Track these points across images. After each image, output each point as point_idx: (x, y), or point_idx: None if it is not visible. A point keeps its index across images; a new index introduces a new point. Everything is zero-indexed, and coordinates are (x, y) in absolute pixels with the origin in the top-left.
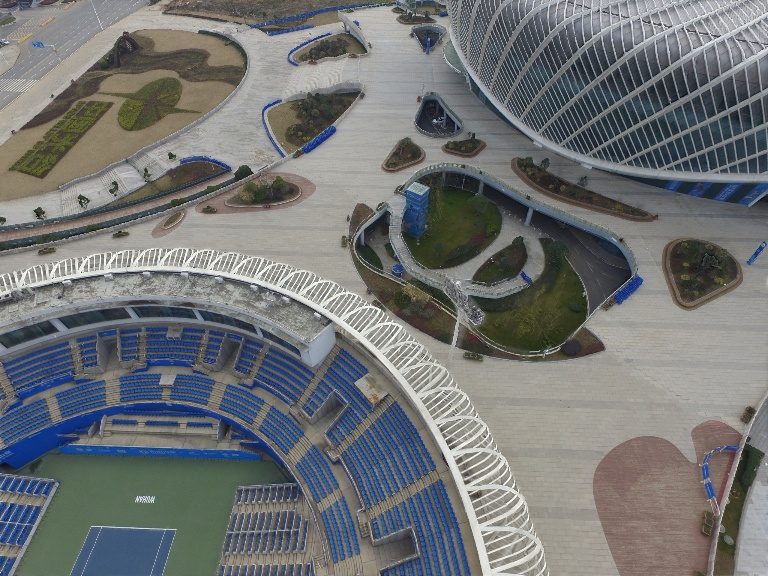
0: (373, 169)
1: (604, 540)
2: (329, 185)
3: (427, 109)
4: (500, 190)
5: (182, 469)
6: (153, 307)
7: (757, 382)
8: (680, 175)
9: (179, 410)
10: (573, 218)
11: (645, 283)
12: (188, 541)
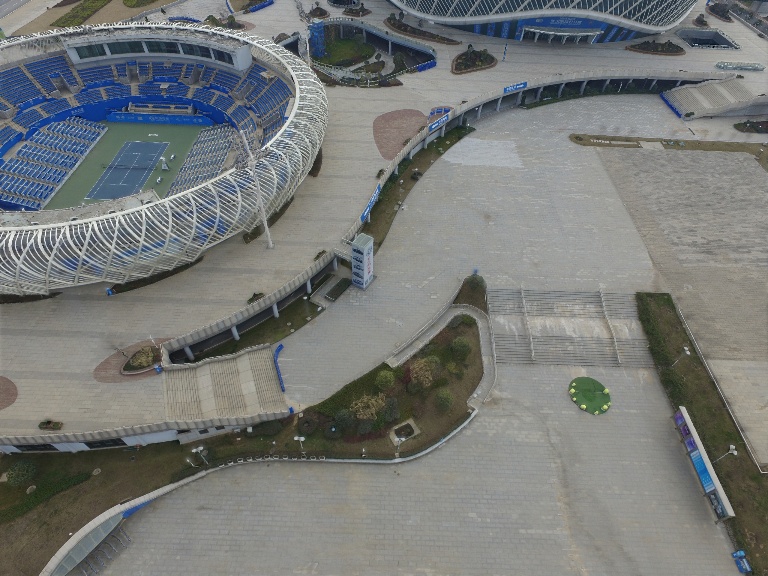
0: (294, 20)
1: (372, 132)
2: (264, 26)
3: (343, 2)
4: (373, 32)
5: (172, 128)
6: (157, 43)
7: (476, 96)
8: (476, 18)
9: (170, 101)
10: (410, 41)
11: (439, 66)
12: (176, 145)
